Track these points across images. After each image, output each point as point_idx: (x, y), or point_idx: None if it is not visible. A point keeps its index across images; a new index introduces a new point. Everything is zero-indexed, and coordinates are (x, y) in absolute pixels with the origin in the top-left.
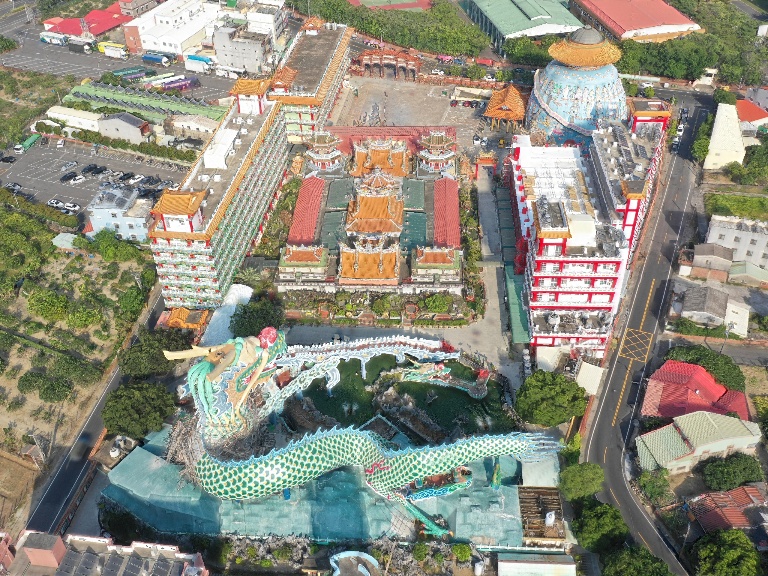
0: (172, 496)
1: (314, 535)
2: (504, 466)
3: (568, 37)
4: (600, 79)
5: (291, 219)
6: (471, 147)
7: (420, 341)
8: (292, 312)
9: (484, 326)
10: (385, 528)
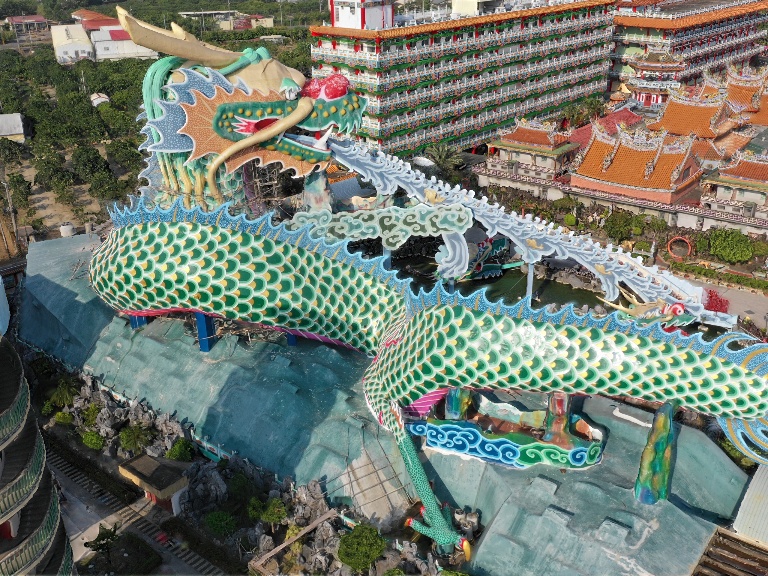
0: (57, 283)
1: (203, 430)
2: (705, 477)
3: None
4: None
5: None
6: None
7: (662, 275)
8: None
9: None
10: (330, 470)
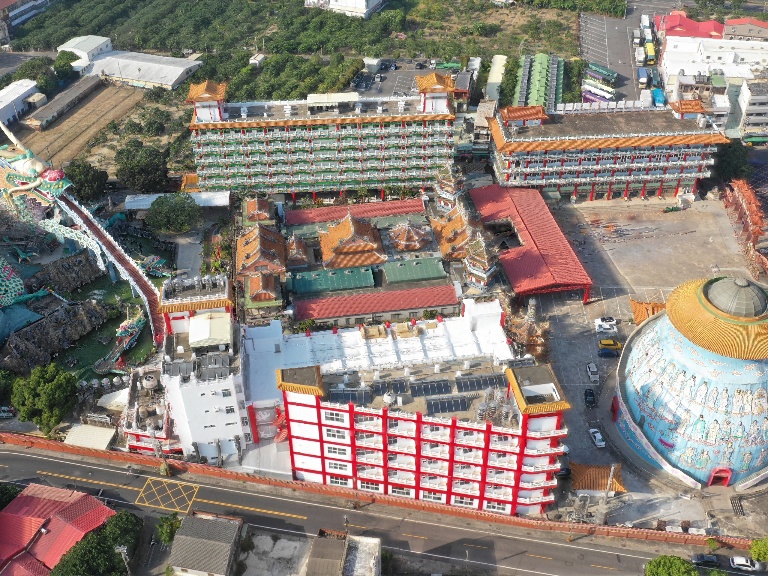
0: None
1: None
2: None
3: (724, 277)
4: (688, 358)
5: (344, 203)
6: (587, 319)
7: None
8: (219, 239)
9: None
10: None
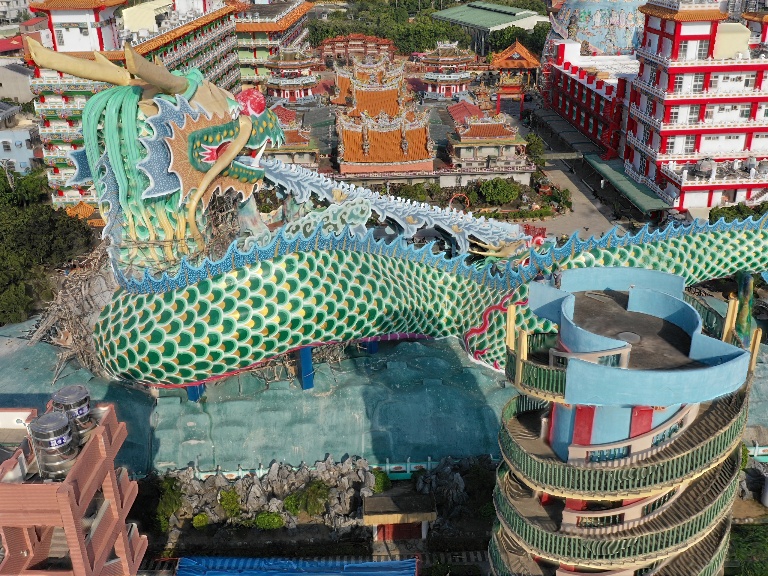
0: (38, 393)
1: (376, 456)
2: None
3: None
4: (637, 1)
5: None
6: None
7: (489, 223)
8: None
9: (578, 217)
10: None
